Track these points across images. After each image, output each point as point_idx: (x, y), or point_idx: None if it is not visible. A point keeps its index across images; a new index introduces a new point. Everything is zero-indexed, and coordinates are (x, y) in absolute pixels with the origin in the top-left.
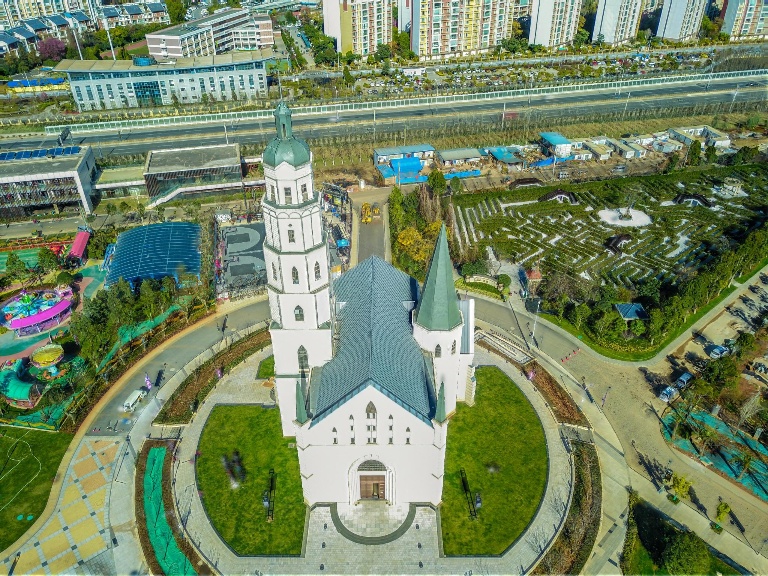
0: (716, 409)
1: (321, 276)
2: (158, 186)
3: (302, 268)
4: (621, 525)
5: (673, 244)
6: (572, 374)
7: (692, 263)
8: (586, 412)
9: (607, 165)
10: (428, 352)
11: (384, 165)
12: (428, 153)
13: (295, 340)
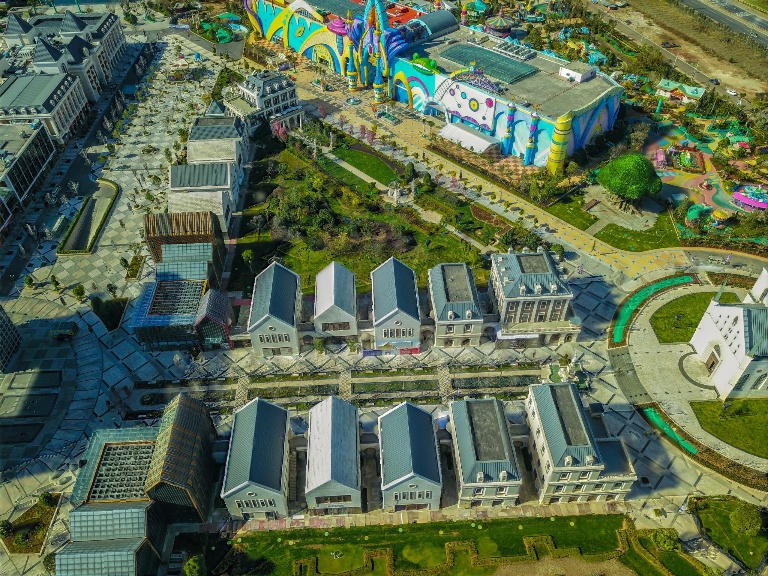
0: None
1: None
2: None
3: None
4: (762, 504)
5: None
6: None
7: None
8: None
9: None
10: None
11: None
12: None
13: None
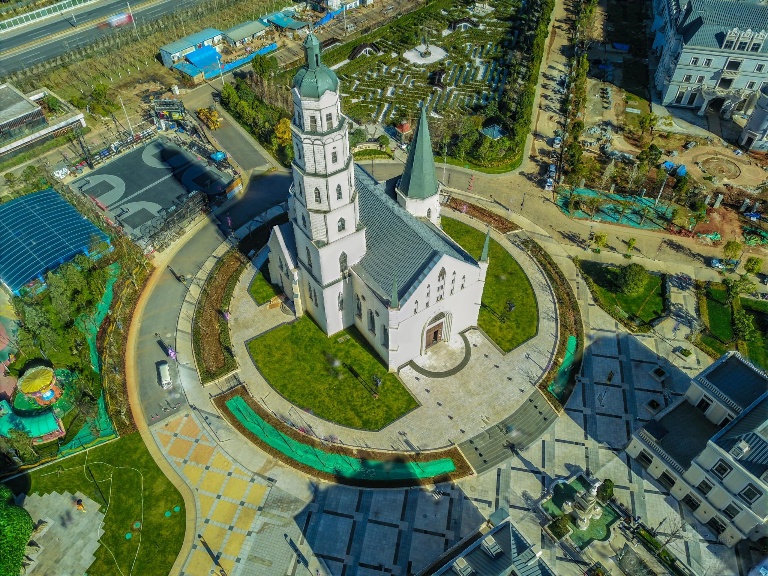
0: (583, 182)
1: (352, 185)
2: None
3: (344, 183)
4: (581, 281)
5: (475, 67)
6: (482, 196)
7: (497, 79)
8: (511, 219)
9: (376, 8)
10: (422, 217)
11: (180, 63)
12: (217, 38)
13: (338, 249)
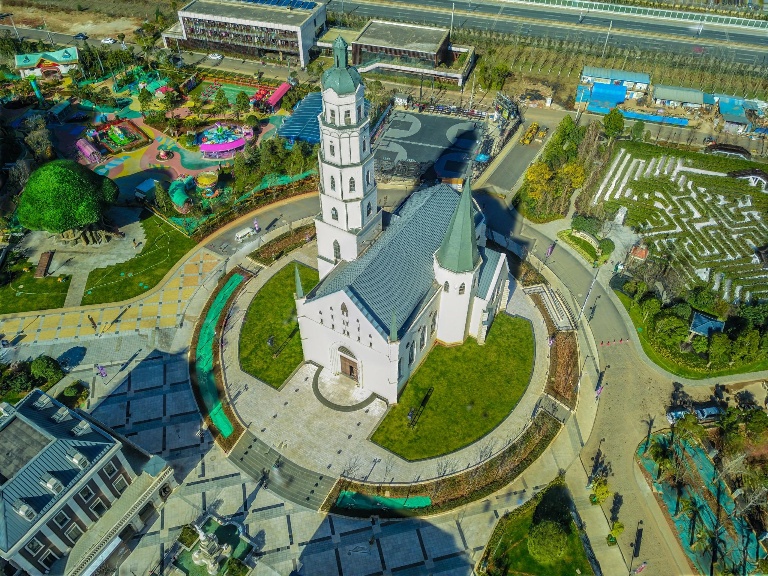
0: (713, 452)
1: (356, 190)
2: (362, 56)
3: (338, 179)
4: (529, 493)
5: None
6: (600, 359)
7: None
8: (582, 396)
9: None
10: (438, 284)
11: (586, 86)
12: (641, 85)
13: (332, 234)
